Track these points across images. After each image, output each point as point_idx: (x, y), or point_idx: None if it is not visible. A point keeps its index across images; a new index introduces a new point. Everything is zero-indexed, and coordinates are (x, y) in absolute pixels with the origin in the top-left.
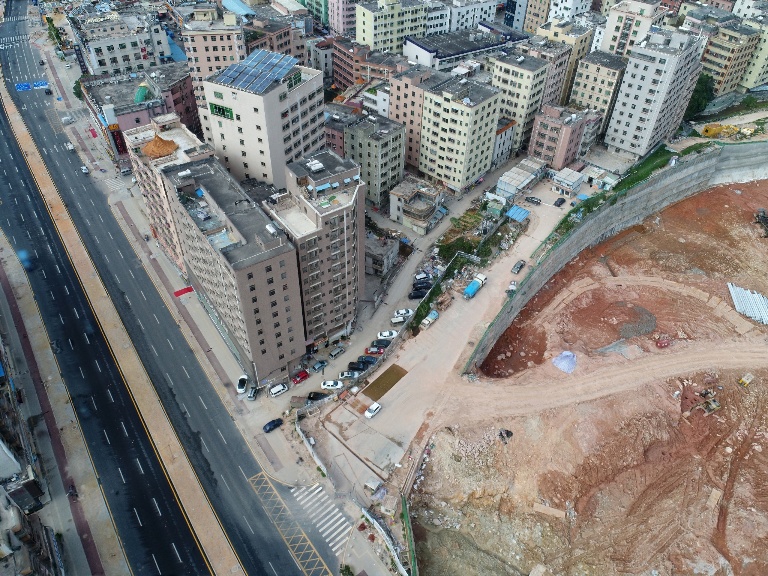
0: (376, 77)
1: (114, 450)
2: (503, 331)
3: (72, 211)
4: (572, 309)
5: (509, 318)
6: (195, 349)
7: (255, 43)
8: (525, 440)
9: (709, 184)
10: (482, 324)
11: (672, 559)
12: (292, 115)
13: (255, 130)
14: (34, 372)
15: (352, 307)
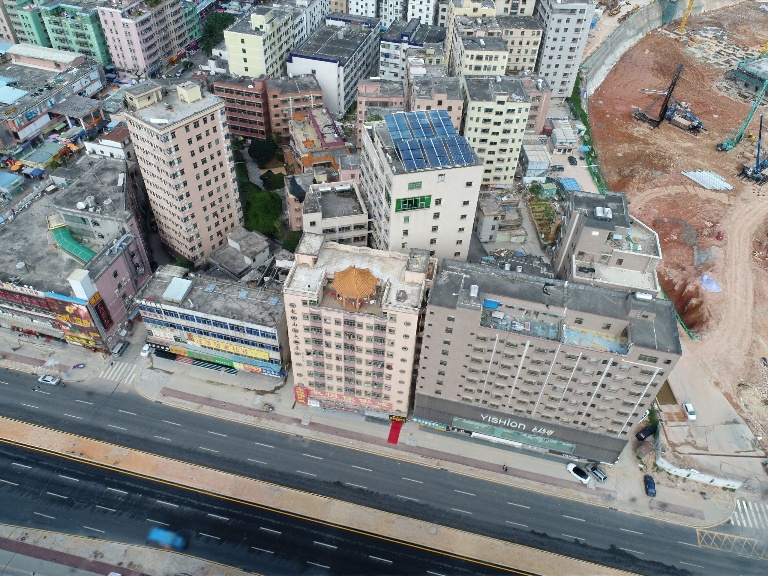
0: (301, 107)
1: None
2: None
3: (118, 440)
4: None
5: None
6: (493, 478)
7: None
8: None
9: None
10: None
11: None
12: None
13: (460, 208)
14: None
15: None
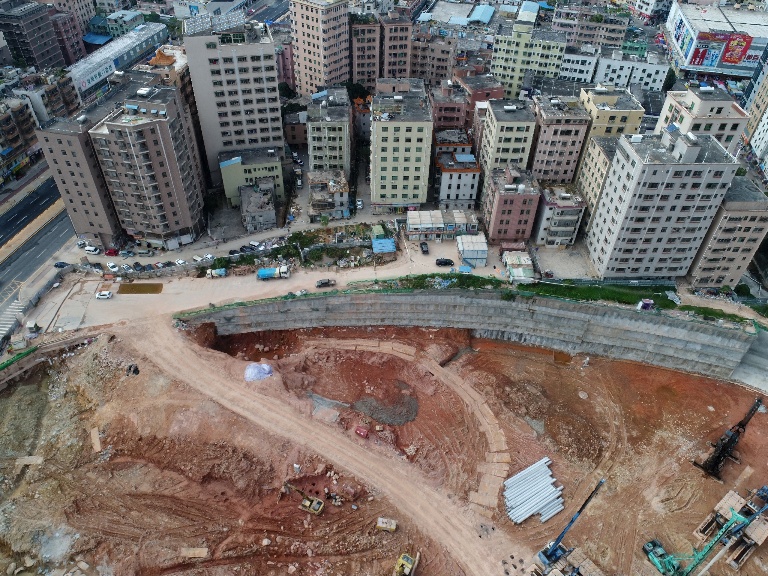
0: None
1: (4, 225)
2: (278, 328)
3: None
4: (354, 356)
5: (292, 322)
6: None
7: (361, 27)
8: (143, 386)
9: (735, 377)
10: (237, 299)
11: (102, 545)
12: (225, 66)
13: None
14: (43, 171)
15: (159, 222)
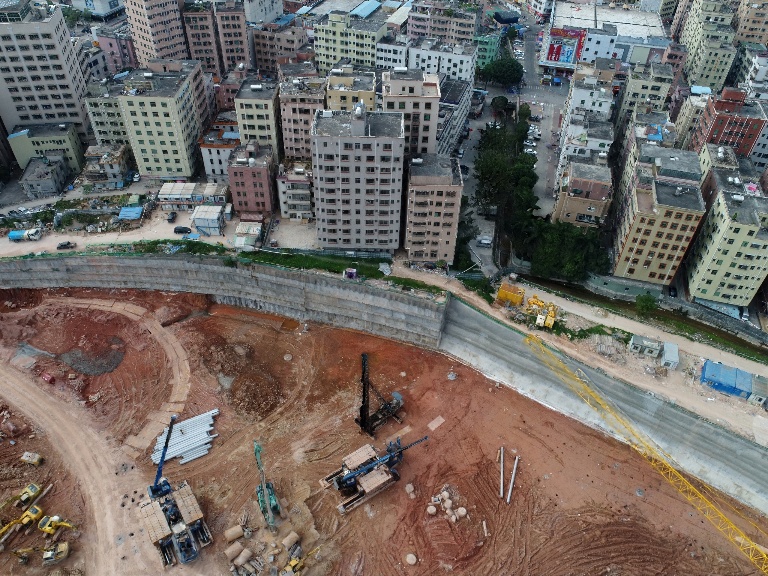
0: None
1: None
2: (26, 287)
3: None
4: (83, 313)
5: (39, 281)
6: None
7: (192, 14)
8: None
9: (443, 348)
10: None
11: None
12: (5, 43)
13: None
14: None
15: None
